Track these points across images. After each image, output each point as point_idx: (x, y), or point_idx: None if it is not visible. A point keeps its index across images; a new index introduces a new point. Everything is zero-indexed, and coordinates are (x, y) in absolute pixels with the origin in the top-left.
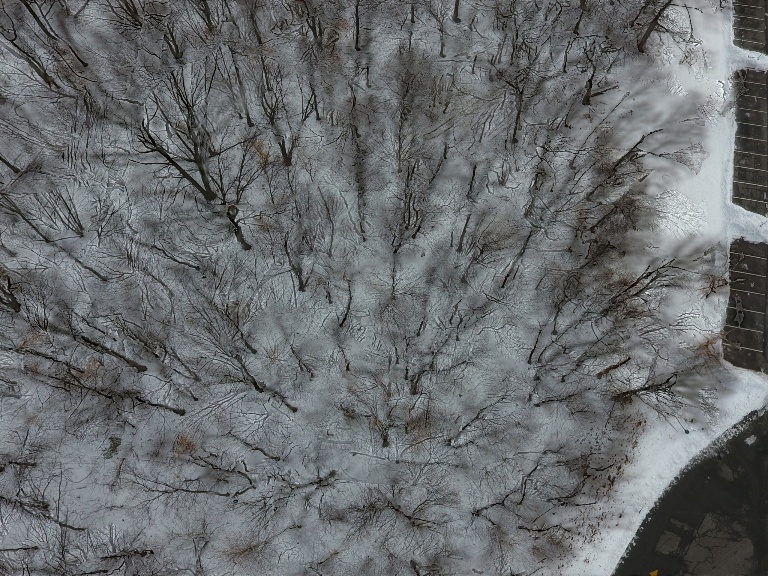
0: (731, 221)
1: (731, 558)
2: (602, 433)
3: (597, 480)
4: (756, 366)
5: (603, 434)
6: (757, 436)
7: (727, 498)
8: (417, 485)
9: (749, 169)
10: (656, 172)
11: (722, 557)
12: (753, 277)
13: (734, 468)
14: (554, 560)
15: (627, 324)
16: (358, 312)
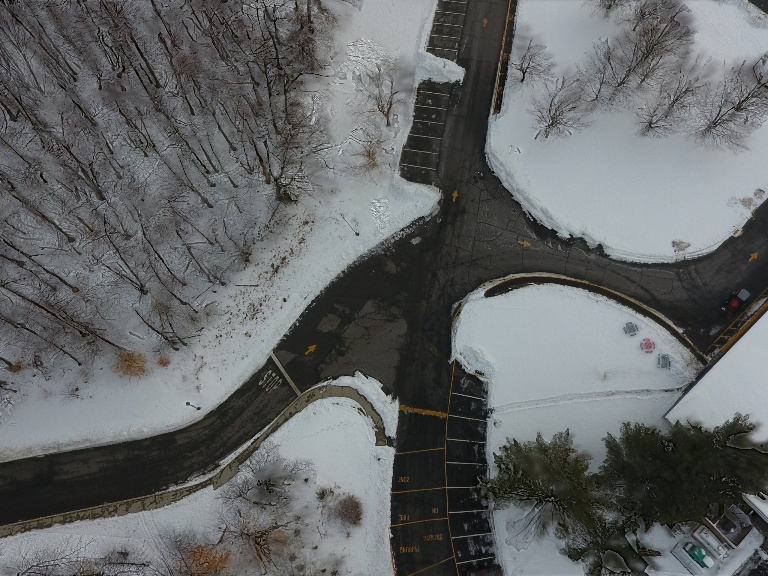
0: (419, 64)
1: (386, 335)
2: (265, 226)
3: (259, 266)
4: (428, 181)
5: (266, 228)
6: (422, 237)
7: (388, 287)
8: (94, 271)
9: (446, 25)
10: (352, 25)
11: (378, 335)
12: (435, 110)
13: (398, 263)
14: (212, 330)
15: (301, 141)
16: (48, 128)
